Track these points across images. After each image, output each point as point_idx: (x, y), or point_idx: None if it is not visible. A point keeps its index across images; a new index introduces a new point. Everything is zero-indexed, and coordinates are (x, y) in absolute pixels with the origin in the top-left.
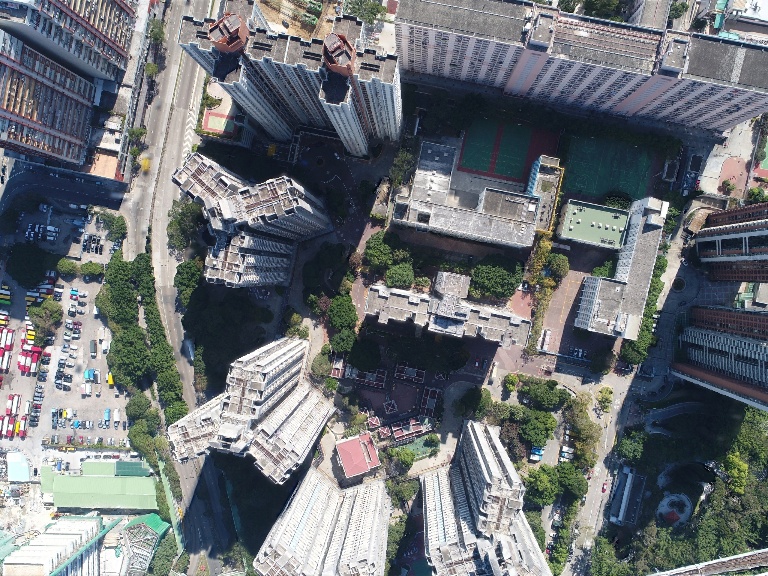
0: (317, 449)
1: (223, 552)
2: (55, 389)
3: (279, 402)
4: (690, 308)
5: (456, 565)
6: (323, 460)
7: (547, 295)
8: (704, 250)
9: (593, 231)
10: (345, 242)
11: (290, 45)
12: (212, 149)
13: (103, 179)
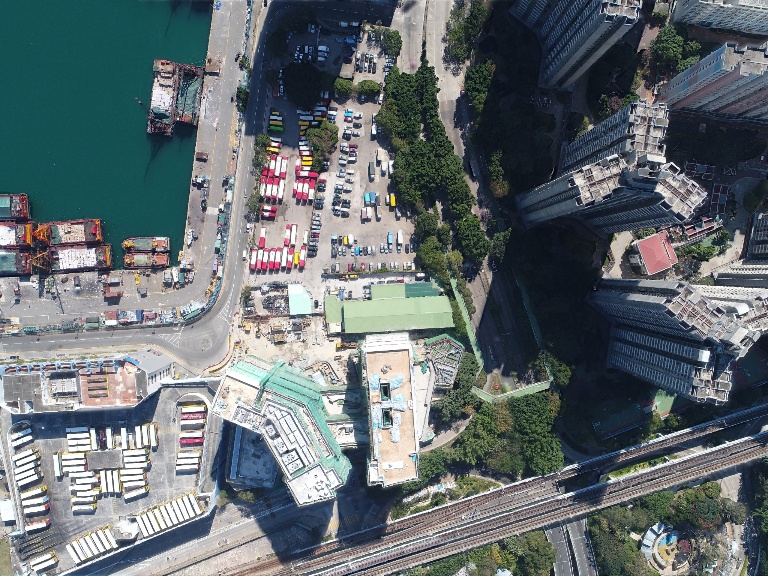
0: (608, 255)
1: (516, 368)
2: (332, 216)
3: None
4: None
5: None
6: (612, 267)
7: None
8: None
9: None
10: None
11: None
12: None
13: None
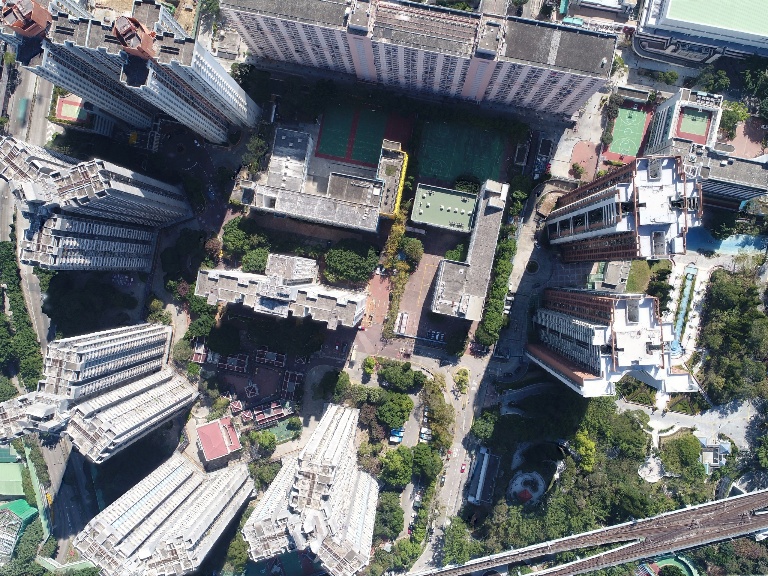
0: (182, 433)
1: None
2: None
3: (123, 385)
4: (543, 290)
5: (269, 540)
6: (189, 444)
7: (402, 278)
8: (552, 232)
9: (442, 215)
10: (206, 228)
11: (92, 29)
12: (70, 137)
13: None
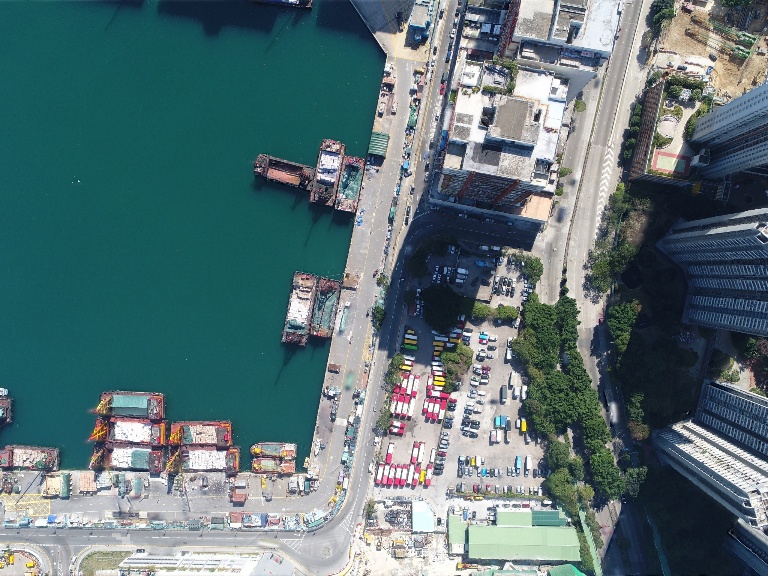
0: None
1: None
2: (461, 436)
3: None
4: None
5: None
6: None
7: None
8: None
9: None
10: None
11: None
12: (647, 189)
13: (514, 219)
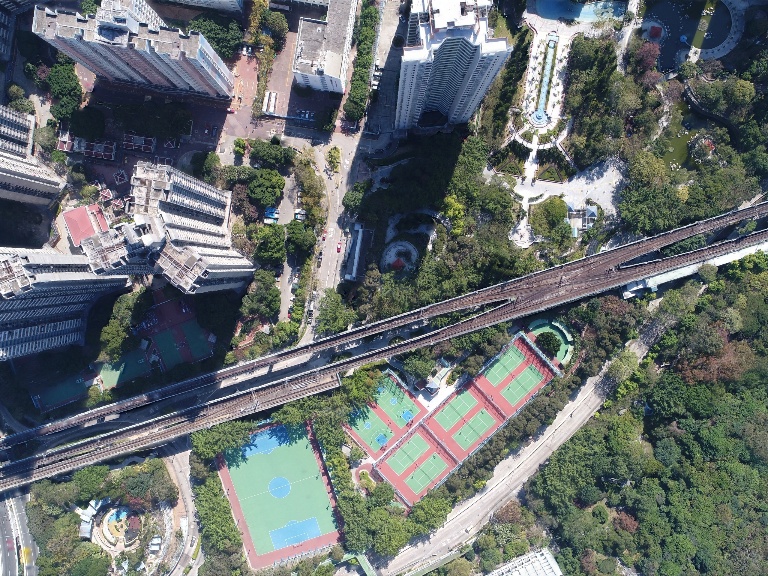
0: (51, 227)
1: None
2: None
3: None
4: None
5: (108, 251)
6: (60, 239)
7: (267, 54)
8: None
9: None
10: None
11: None
12: None
13: None
